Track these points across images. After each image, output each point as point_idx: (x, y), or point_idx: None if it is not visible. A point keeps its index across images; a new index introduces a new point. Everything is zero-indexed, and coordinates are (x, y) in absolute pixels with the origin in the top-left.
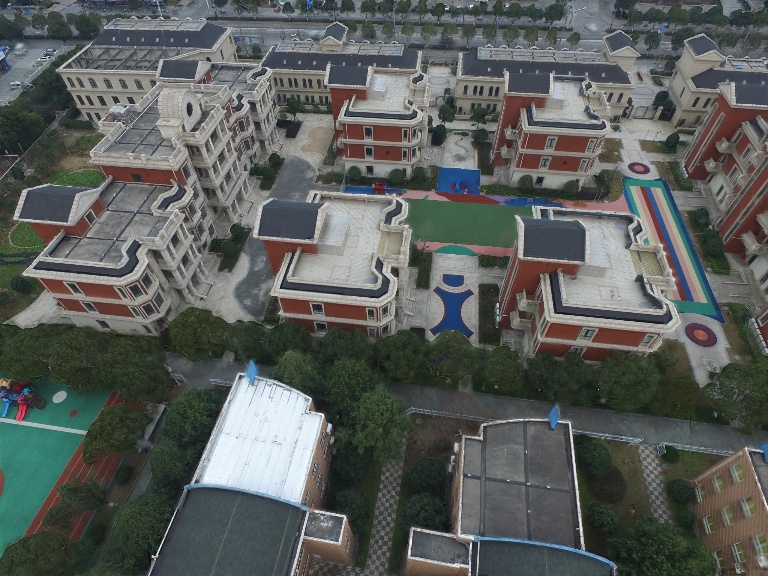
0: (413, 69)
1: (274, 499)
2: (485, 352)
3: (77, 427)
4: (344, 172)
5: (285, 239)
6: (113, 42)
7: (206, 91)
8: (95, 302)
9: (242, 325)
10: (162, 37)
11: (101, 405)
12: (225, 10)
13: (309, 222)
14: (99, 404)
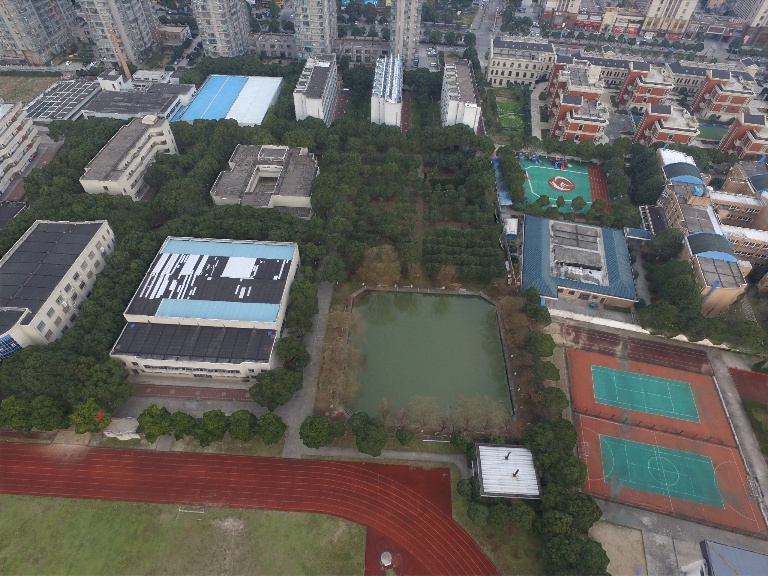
0: (660, 67)
1: (694, 166)
2: (727, 155)
3: (584, 172)
4: (627, 110)
5: (660, 114)
6: (505, 47)
7: None
8: (583, 134)
9: (639, 144)
10: (530, 46)
11: (587, 168)
12: (503, 34)
13: (668, 109)
14: (586, 168)
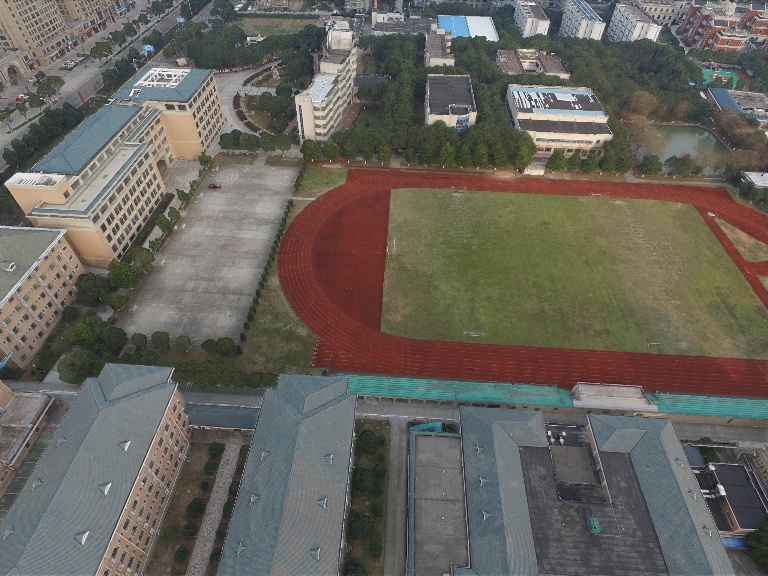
0: None
1: None
2: None
3: (732, 72)
4: None
5: None
6: None
7: (720, 8)
8: None
9: None
10: None
11: None
12: None
13: None
14: (732, 70)
